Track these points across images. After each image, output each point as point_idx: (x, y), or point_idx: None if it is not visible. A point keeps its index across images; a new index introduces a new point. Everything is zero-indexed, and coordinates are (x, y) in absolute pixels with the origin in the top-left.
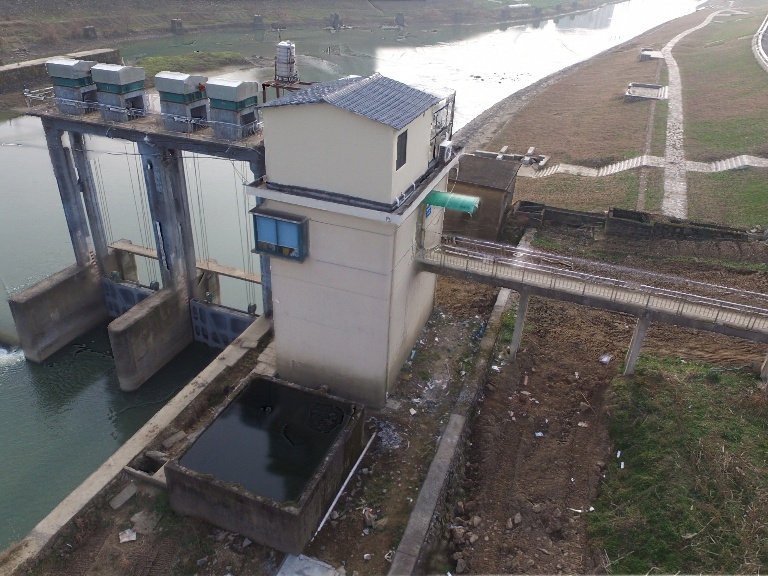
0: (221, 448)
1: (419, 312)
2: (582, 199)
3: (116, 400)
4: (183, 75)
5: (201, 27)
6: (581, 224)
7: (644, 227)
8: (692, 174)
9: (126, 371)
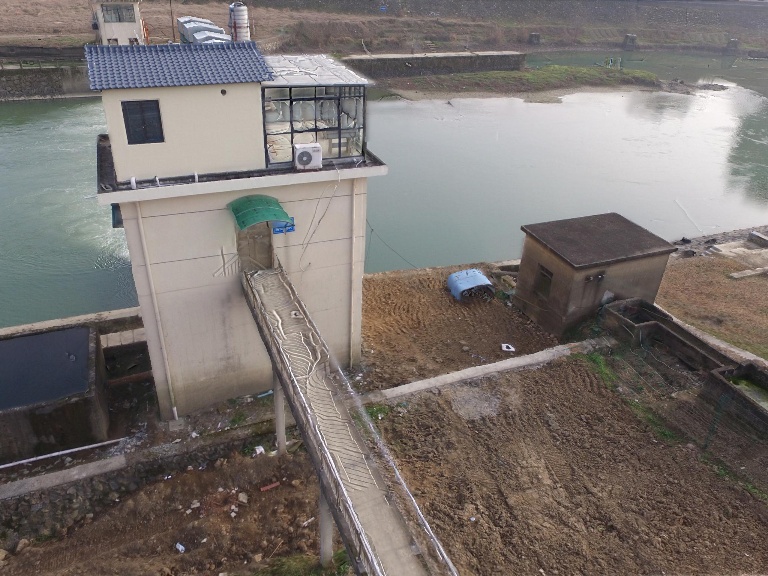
0: None
1: None
2: None
3: None
4: (207, 35)
5: (658, 46)
6: (698, 367)
7: (757, 413)
8: None
9: None
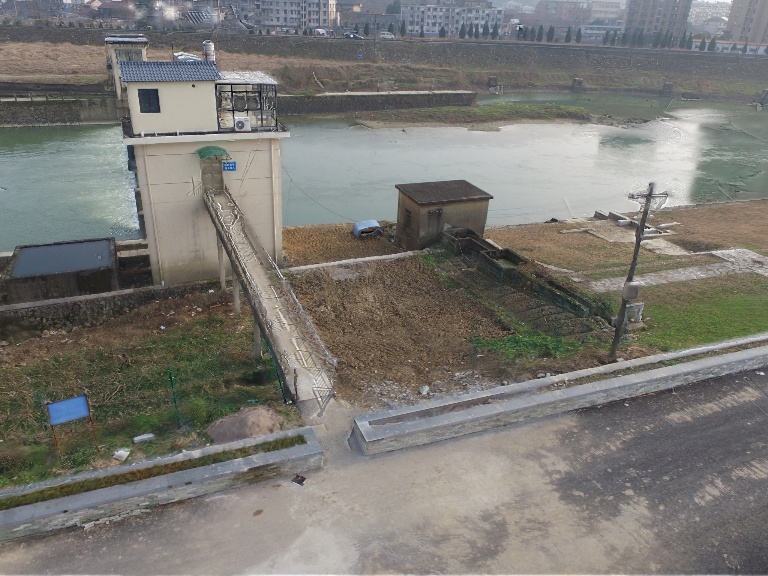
0: (50, 256)
1: None
2: (571, 257)
3: None
4: None
5: (603, 88)
6: None
7: (497, 268)
8: (746, 274)
9: None
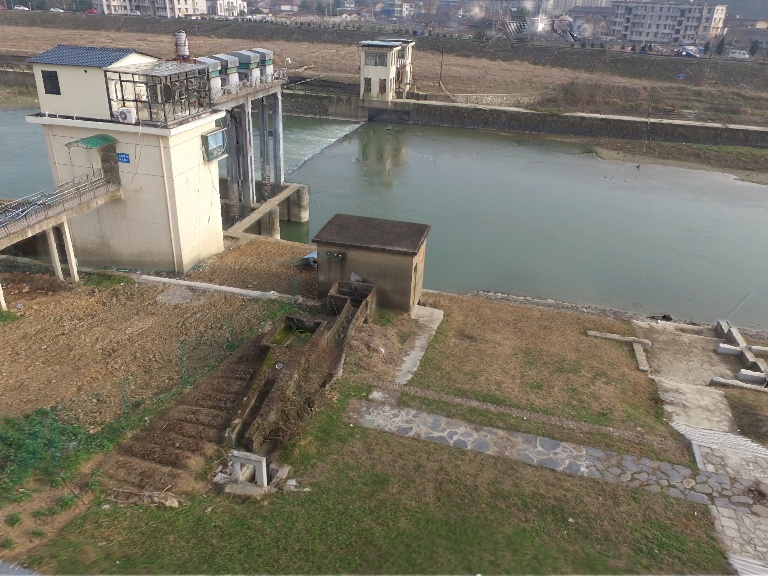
0: None
1: (137, 245)
2: None
3: None
4: None
5: None
6: None
7: None
8: (675, 504)
9: None
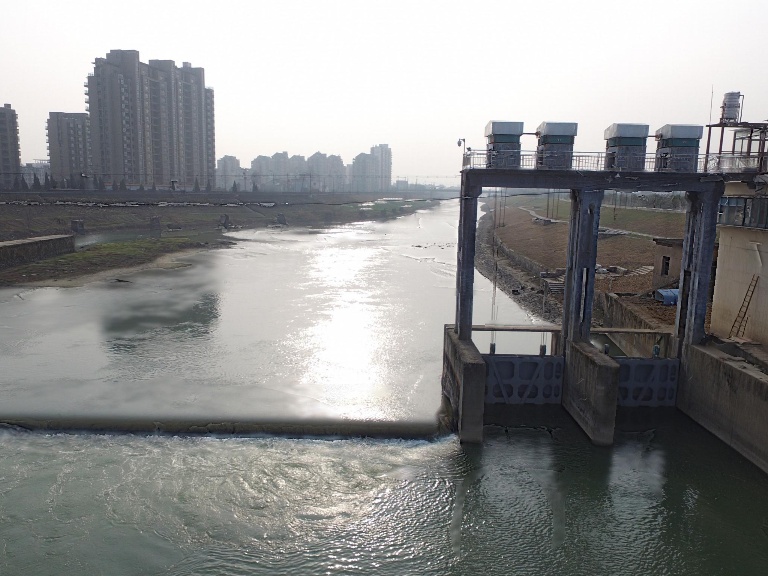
0: None
1: None
2: None
3: (588, 462)
4: None
5: (99, 228)
6: None
7: None
8: None
9: (613, 418)
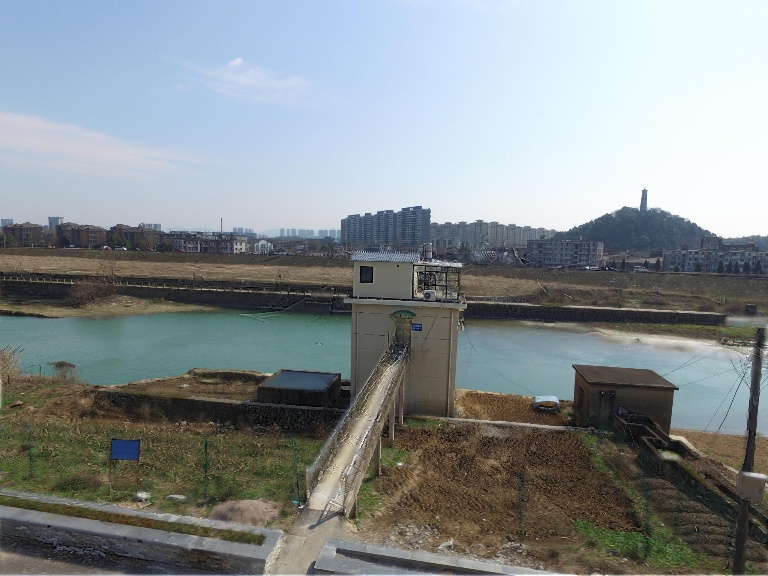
0: None
1: (415, 396)
2: None
3: None
4: None
5: None
6: None
7: (655, 457)
8: None
9: None
